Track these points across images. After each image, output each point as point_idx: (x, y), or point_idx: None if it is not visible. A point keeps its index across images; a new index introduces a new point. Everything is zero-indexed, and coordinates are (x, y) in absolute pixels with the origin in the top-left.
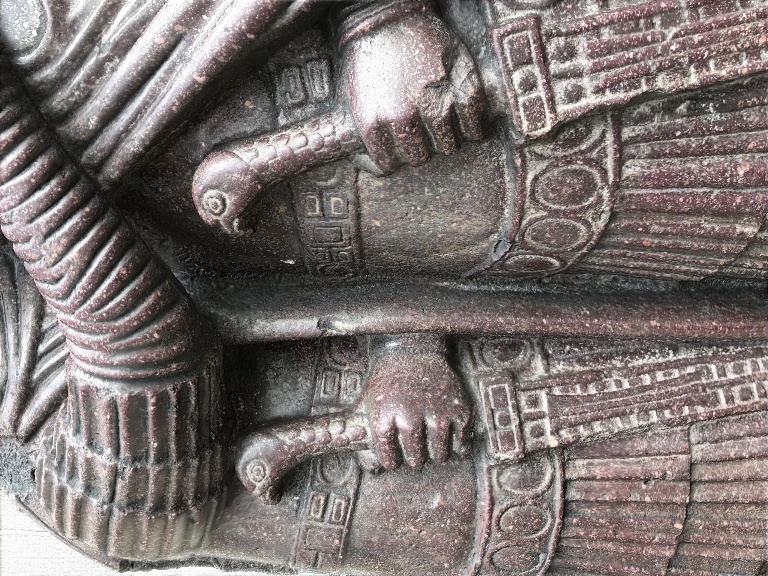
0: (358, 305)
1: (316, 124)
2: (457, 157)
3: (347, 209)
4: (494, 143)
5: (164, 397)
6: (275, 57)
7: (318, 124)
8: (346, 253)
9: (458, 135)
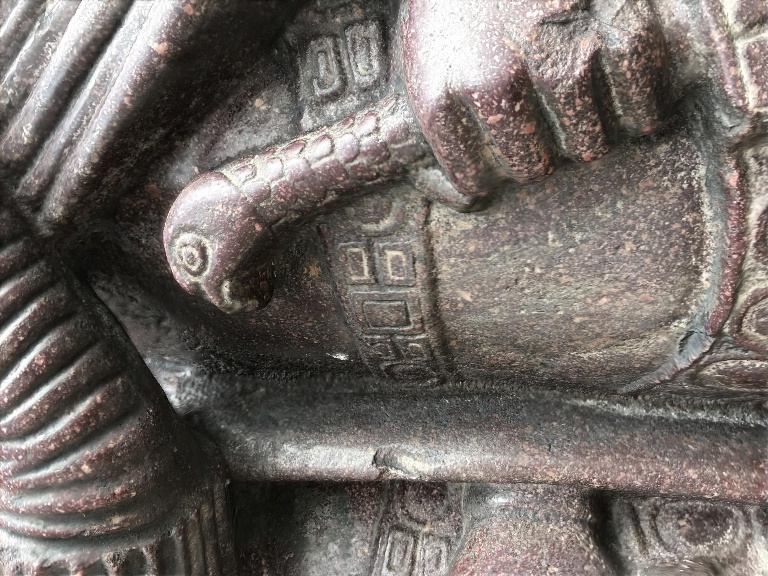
0: (441, 431)
1: (350, 118)
2: (607, 174)
3: (414, 271)
4: (681, 145)
5: (98, 573)
6: (297, 24)
7: (353, 118)
8: (419, 345)
9: (609, 119)
